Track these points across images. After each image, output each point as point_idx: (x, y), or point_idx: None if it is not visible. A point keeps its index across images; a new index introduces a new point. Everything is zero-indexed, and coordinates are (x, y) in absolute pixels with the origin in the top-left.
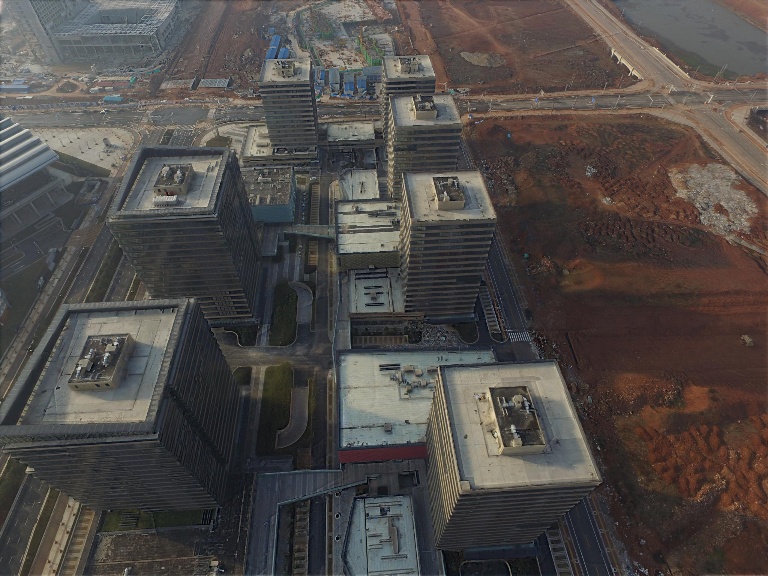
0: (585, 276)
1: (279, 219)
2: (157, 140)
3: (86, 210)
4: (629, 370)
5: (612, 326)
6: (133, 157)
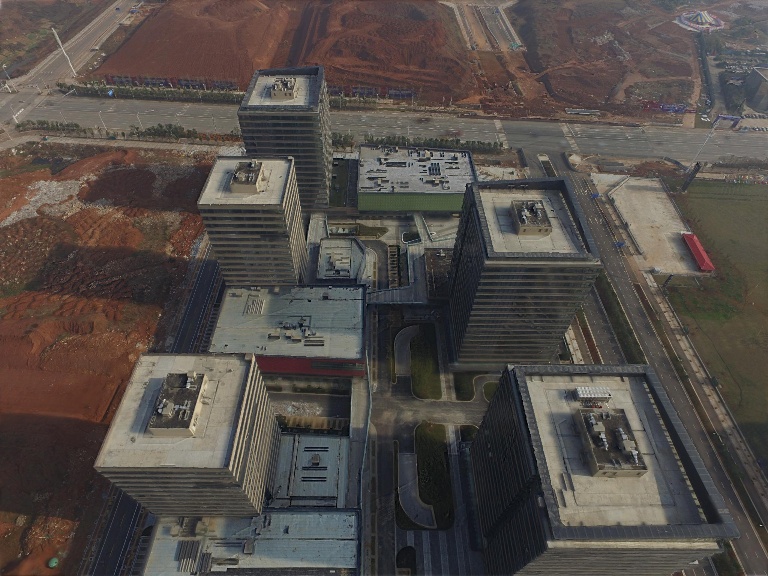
0: (5, 500)
1: None
2: None
3: None
4: (75, 372)
5: (46, 417)
6: None
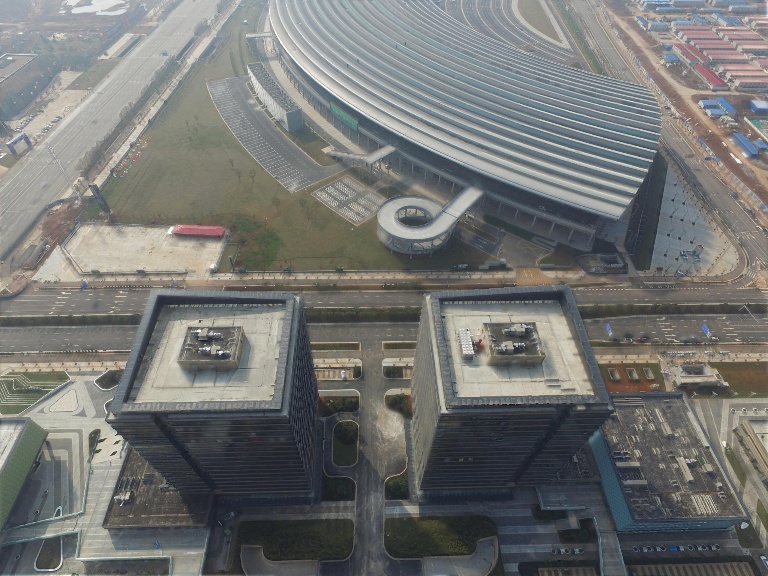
0: None
1: (613, 506)
2: (738, 299)
3: (573, 268)
4: None
5: None
6: (540, 286)
